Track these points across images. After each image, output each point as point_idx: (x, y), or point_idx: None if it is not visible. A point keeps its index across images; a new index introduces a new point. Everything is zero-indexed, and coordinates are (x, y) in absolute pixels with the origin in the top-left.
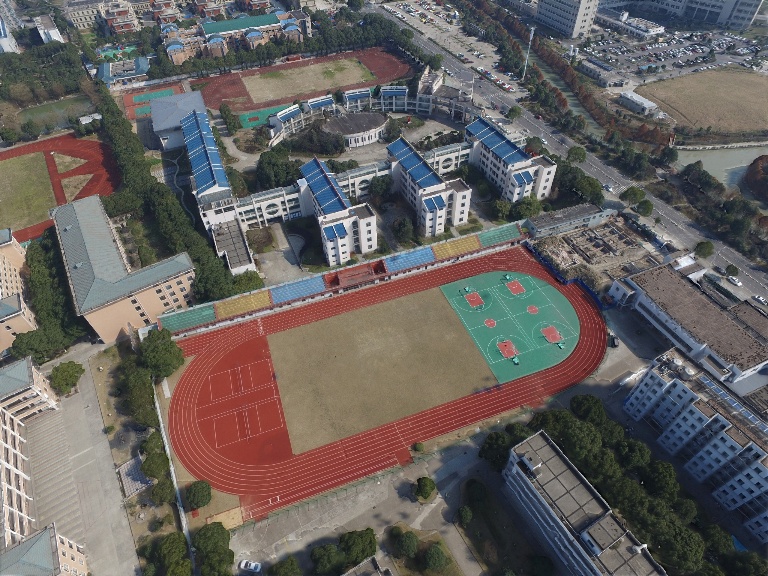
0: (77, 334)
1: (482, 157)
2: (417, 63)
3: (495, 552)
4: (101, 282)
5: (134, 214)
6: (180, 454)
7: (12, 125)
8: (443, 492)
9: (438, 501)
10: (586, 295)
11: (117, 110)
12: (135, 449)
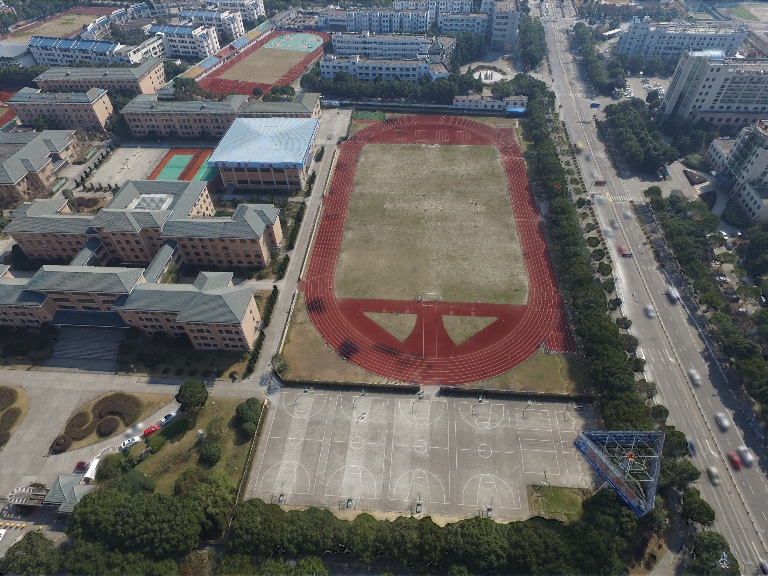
0: None
1: None
2: (121, 4)
3: None
4: (132, 68)
5: None
6: None
7: None
8: None
9: None
10: (312, 30)
11: None
12: None
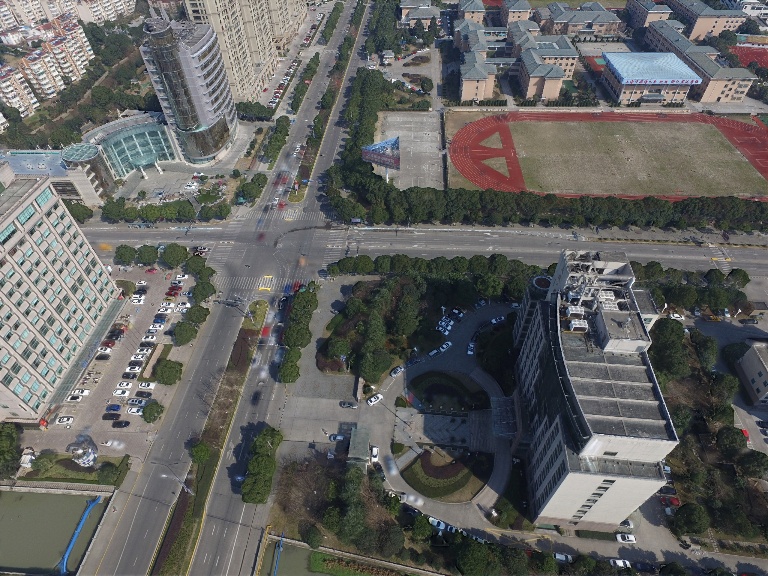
0: (684, 29)
1: None
2: None
3: None
4: (710, 8)
5: None
6: None
7: None
8: None
9: None
10: None
11: None
12: None
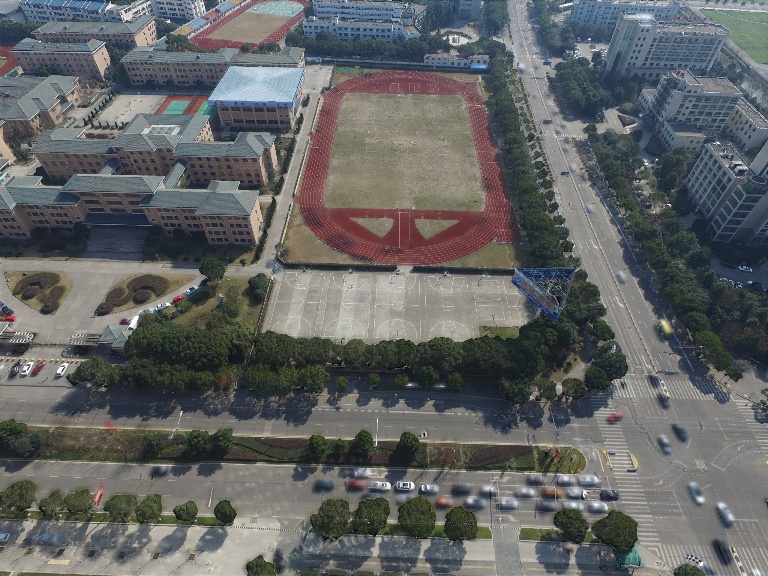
0: None
1: None
2: None
3: None
4: (127, 24)
5: None
6: None
7: None
8: None
9: None
10: None
11: None
12: None
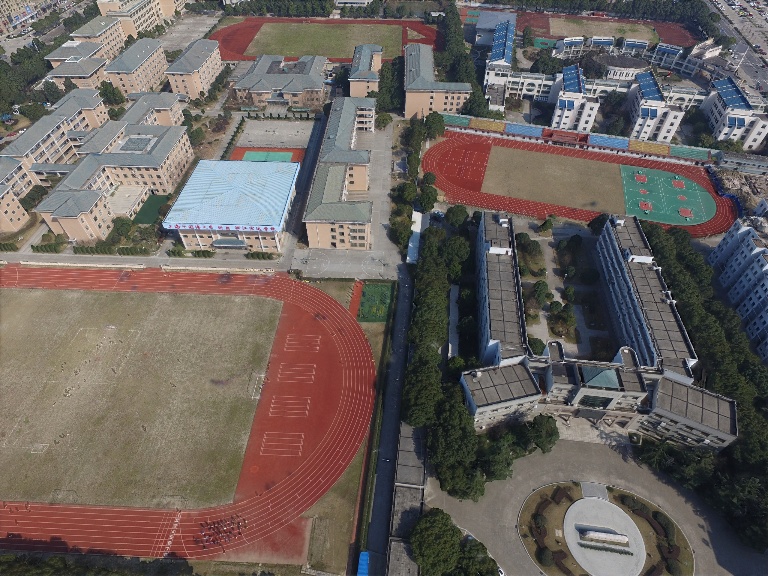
0: (396, 104)
1: (713, 107)
2: None
3: (569, 259)
4: (422, 79)
5: (444, 67)
6: (424, 169)
7: (393, 5)
8: (555, 237)
9: (550, 238)
10: (734, 207)
11: (457, 12)
12: (404, 159)
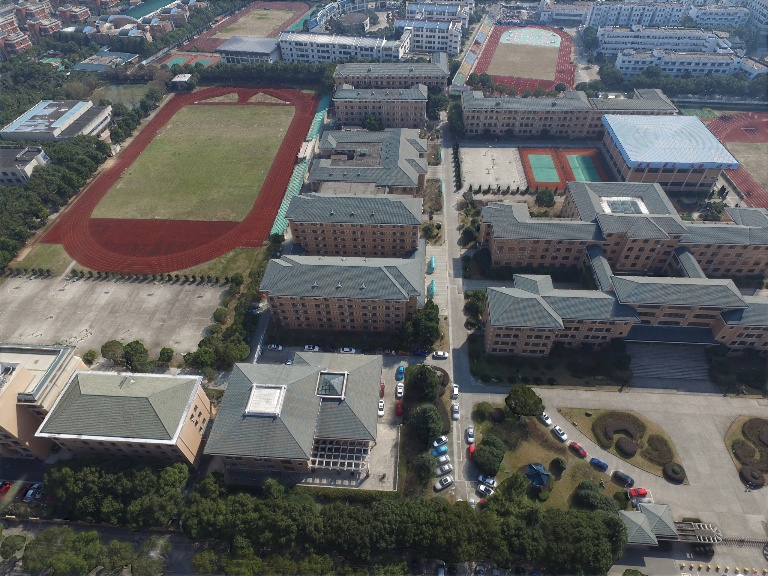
0: None
1: None
2: None
3: None
4: (437, 64)
5: None
6: None
7: (139, 97)
8: None
9: None
10: (535, 25)
11: None
12: None
